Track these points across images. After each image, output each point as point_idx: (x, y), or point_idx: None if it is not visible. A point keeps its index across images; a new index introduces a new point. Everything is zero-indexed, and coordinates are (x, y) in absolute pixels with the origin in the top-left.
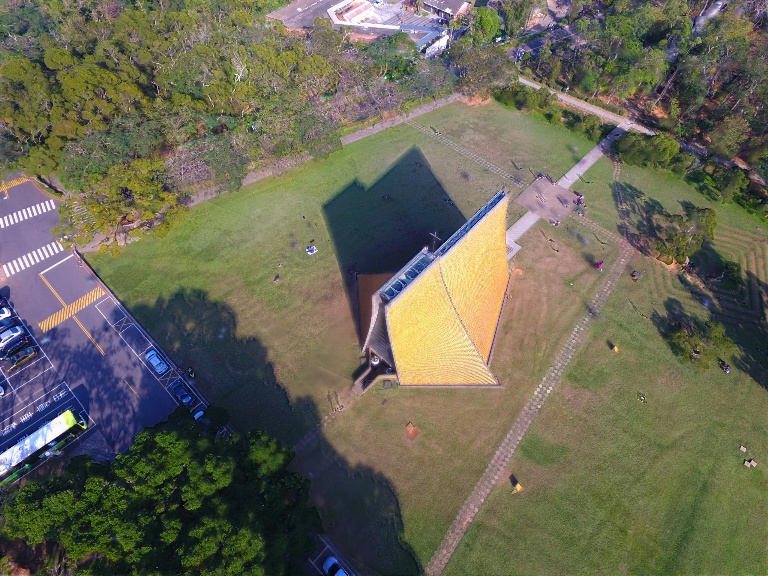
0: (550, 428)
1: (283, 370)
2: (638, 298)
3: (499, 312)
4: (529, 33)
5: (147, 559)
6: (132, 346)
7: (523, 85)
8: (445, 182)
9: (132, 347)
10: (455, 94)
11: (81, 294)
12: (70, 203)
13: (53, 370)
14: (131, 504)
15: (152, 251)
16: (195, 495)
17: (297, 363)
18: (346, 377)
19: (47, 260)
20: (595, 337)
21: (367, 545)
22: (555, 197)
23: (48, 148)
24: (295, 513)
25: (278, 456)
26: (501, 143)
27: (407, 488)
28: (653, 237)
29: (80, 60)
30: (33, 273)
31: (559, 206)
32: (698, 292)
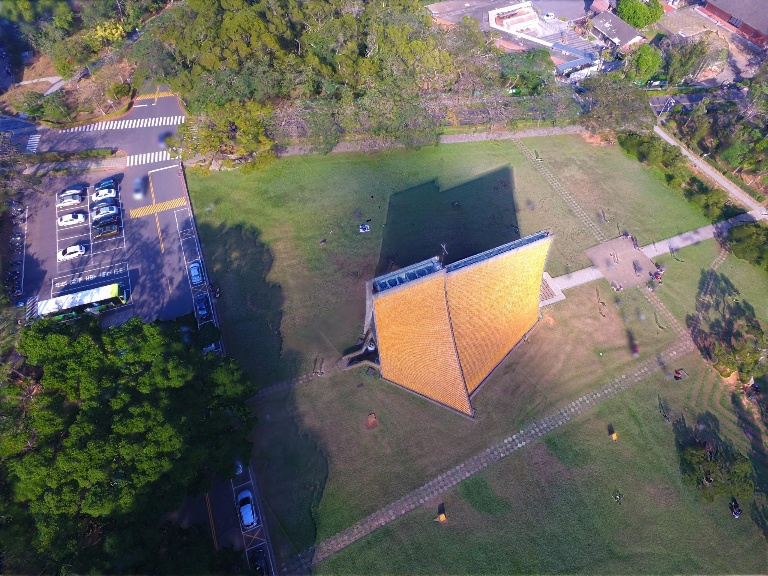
0: (503, 480)
1: (290, 321)
2: (670, 397)
3: (509, 350)
4: (697, 85)
5: (92, 412)
6: (185, 254)
7: (659, 137)
8: (521, 209)
9: (185, 254)
10: (578, 126)
11: (169, 198)
12: (187, 122)
13: (124, 250)
14: (102, 367)
15: (236, 183)
16: (149, 382)
17: (304, 320)
18: (338, 350)
19: (159, 163)
20: (598, 415)
21: (283, 497)
22: (631, 262)
23: (190, 72)
24: (230, 438)
25: (238, 386)
26: (601, 189)
27: (342, 468)
28: (725, 342)
29: (248, 6)
30: (145, 170)
31: (631, 272)
32: (748, 420)
